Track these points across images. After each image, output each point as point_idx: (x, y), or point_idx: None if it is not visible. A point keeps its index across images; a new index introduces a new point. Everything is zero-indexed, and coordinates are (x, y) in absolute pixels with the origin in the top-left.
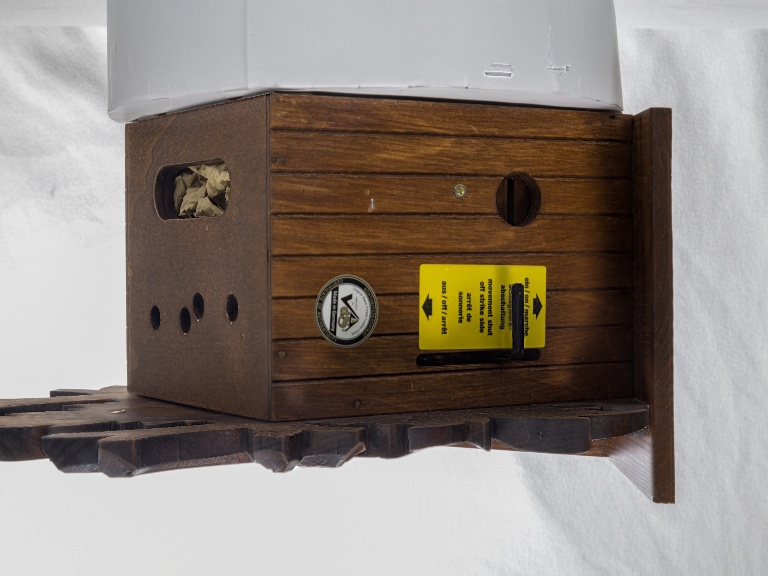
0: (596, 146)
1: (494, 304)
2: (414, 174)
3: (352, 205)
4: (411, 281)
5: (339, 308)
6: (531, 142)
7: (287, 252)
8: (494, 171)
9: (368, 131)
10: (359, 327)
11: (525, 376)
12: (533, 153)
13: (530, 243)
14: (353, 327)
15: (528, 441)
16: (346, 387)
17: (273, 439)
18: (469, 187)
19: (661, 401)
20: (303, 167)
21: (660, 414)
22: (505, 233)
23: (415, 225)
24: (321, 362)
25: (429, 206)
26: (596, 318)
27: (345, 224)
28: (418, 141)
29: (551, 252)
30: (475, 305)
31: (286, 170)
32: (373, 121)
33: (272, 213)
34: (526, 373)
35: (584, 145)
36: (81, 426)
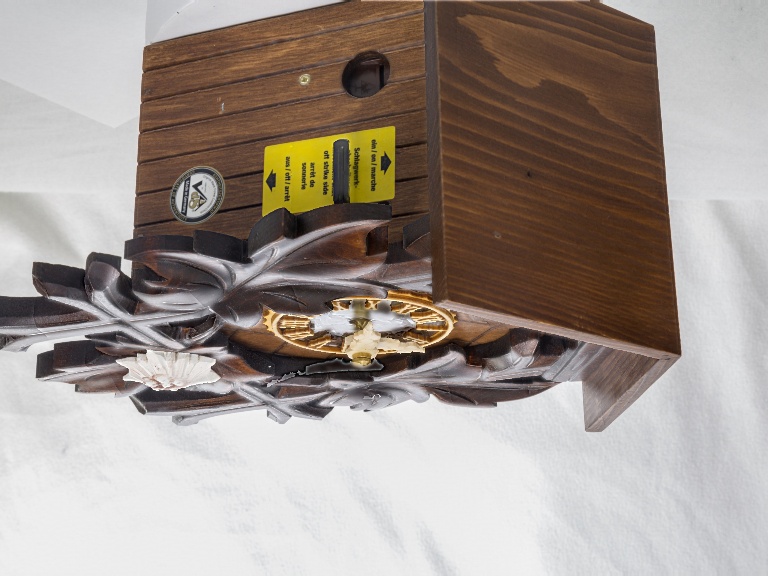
0: None
1: None
2: (263, 76)
3: (206, 112)
4: (257, 162)
5: (190, 194)
6: (379, 24)
7: (150, 158)
8: (340, 56)
9: (223, 53)
10: (207, 206)
11: None
12: (381, 32)
13: (378, 109)
14: (202, 207)
15: None
16: None
17: None
18: (314, 75)
19: (433, 202)
20: (166, 92)
21: (433, 215)
22: (351, 105)
23: (262, 116)
24: None
25: (275, 98)
26: None
27: (199, 128)
28: (266, 50)
29: (403, 113)
30: (319, 172)
31: (153, 98)
32: (226, 44)
33: (141, 132)
34: None
35: None
36: (77, 342)
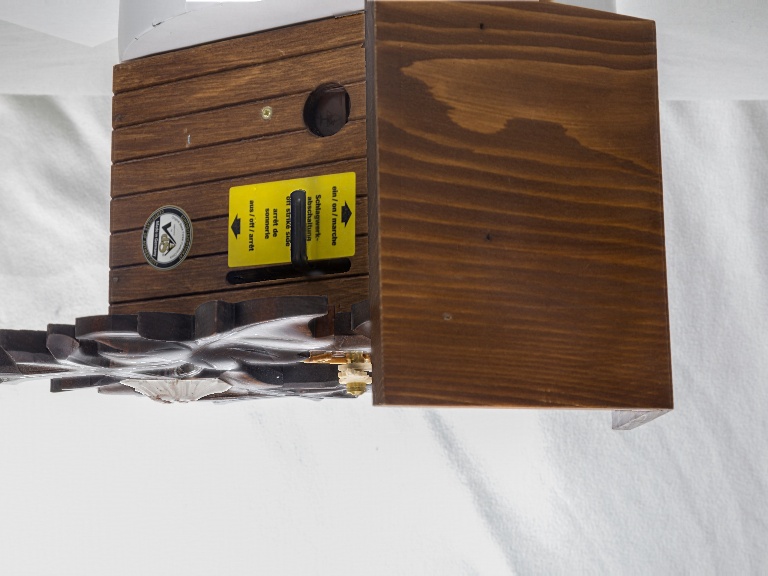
0: None
1: None
2: (228, 106)
3: (173, 144)
4: (222, 204)
5: (160, 236)
6: (339, 50)
7: (122, 193)
8: (301, 87)
9: (188, 77)
10: (176, 251)
11: (334, 287)
12: (342, 61)
13: (338, 151)
14: (171, 251)
15: None
16: (165, 306)
17: None
18: (276, 107)
19: (372, 289)
20: (135, 119)
21: (372, 304)
22: (312, 145)
23: (226, 152)
24: (146, 284)
25: (239, 132)
26: None
27: (167, 162)
28: (230, 75)
29: (363, 157)
30: (282, 220)
31: (124, 125)
32: (191, 67)
33: (113, 162)
34: (335, 284)
35: None
36: None
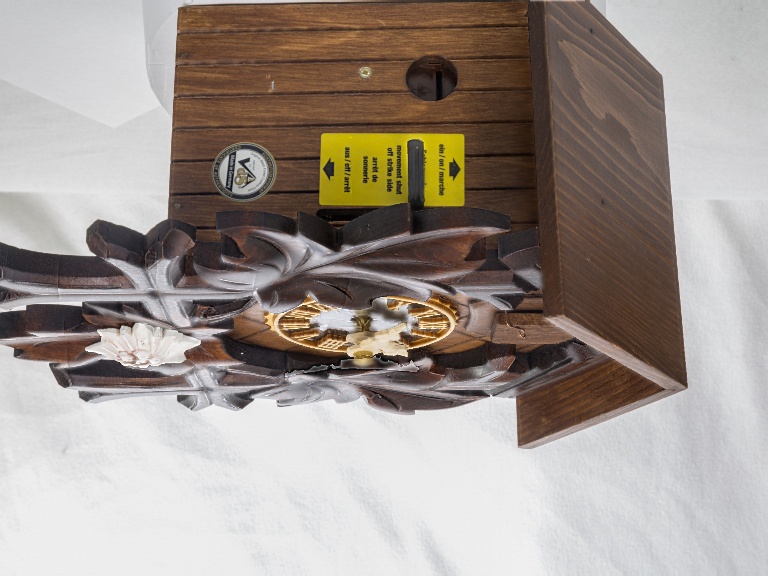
0: (522, 30)
1: (404, 167)
2: (318, 61)
3: (253, 87)
4: (312, 147)
5: (236, 169)
6: (445, 30)
7: (187, 125)
8: (403, 55)
9: (271, 30)
10: (256, 185)
11: None
12: (448, 39)
13: (445, 114)
14: (250, 185)
15: (360, 236)
16: None
17: (93, 224)
18: (376, 69)
19: (545, 217)
20: (206, 59)
21: (544, 230)
22: (416, 106)
23: (317, 102)
24: None
25: (332, 86)
26: (527, 181)
27: (245, 102)
28: (321, 35)
29: (471, 123)
30: (382, 168)
31: (190, 63)
32: (276, 21)
33: (176, 96)
34: None
35: (507, 30)
36: (55, 305)
